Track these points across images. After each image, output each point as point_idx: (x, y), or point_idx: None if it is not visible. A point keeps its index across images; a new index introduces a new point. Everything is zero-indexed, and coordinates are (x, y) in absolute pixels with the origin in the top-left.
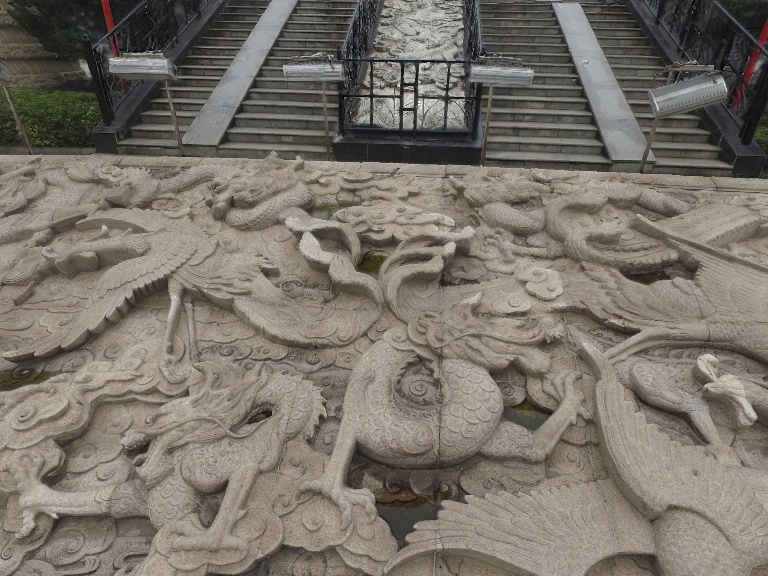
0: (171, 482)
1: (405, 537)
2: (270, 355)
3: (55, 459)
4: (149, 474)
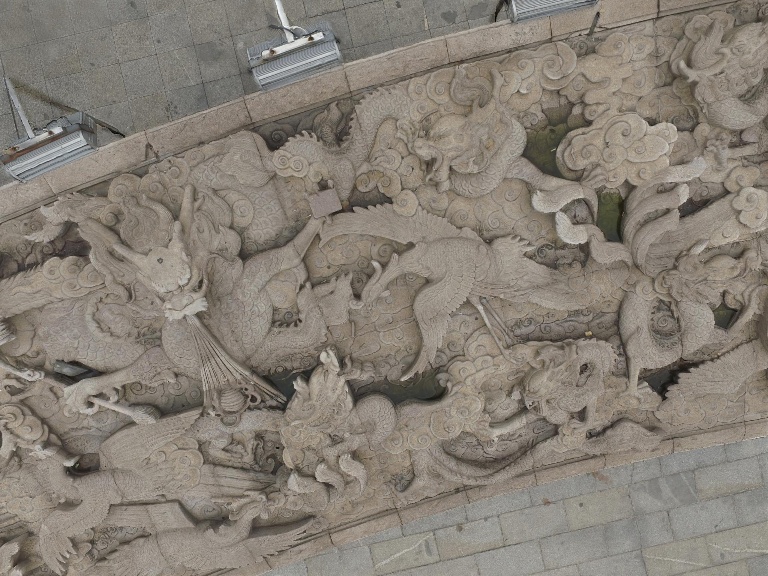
0: (557, 413)
1: (665, 395)
2: (558, 318)
3: (489, 418)
4: (547, 415)
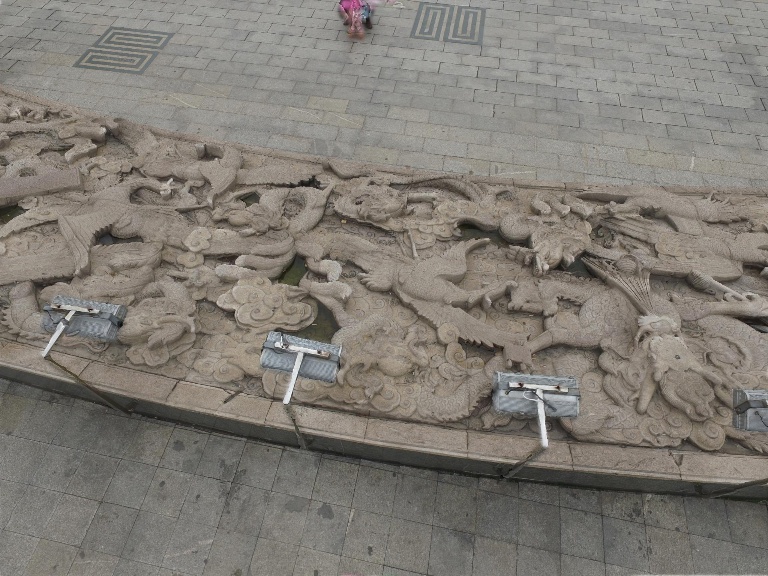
0: None
1: None
2: None
3: None
4: None
